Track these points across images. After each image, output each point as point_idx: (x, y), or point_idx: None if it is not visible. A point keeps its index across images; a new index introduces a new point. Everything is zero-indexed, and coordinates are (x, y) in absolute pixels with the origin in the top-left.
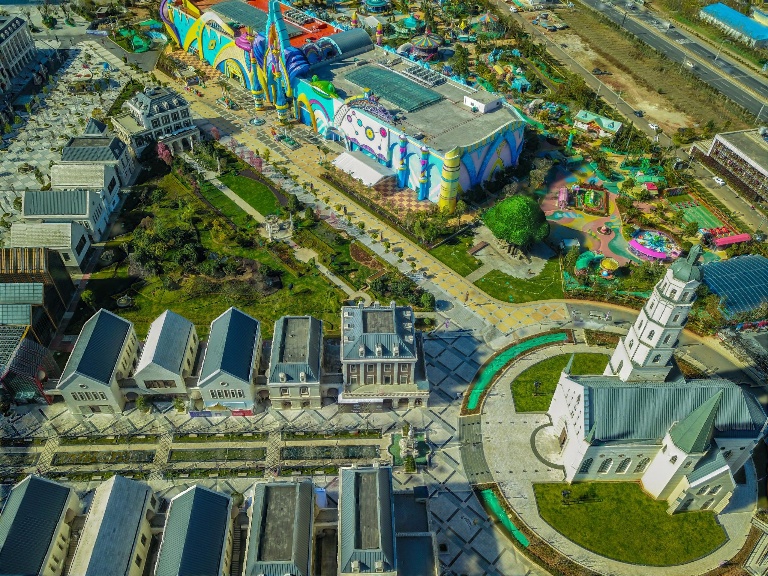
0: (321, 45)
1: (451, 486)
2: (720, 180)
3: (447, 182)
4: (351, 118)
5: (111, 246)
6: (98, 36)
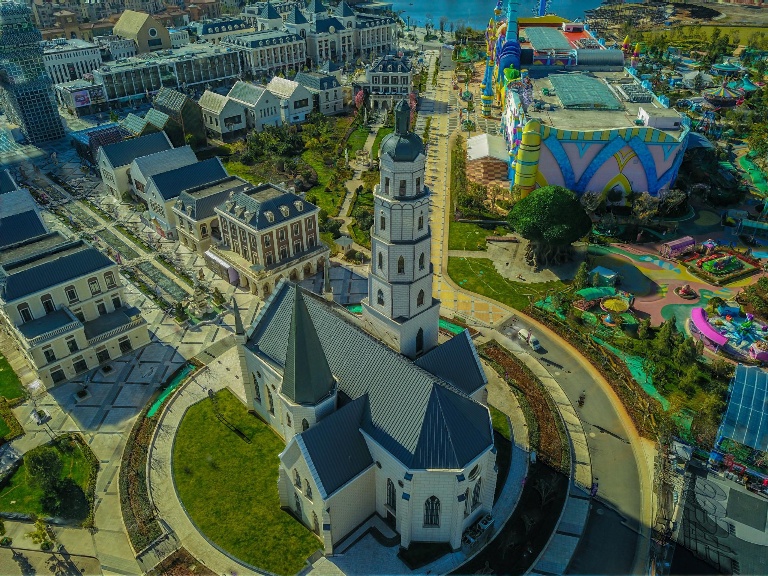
0: (572, 60)
1: (182, 348)
2: None
3: (518, 163)
4: None
5: None
6: (448, 49)
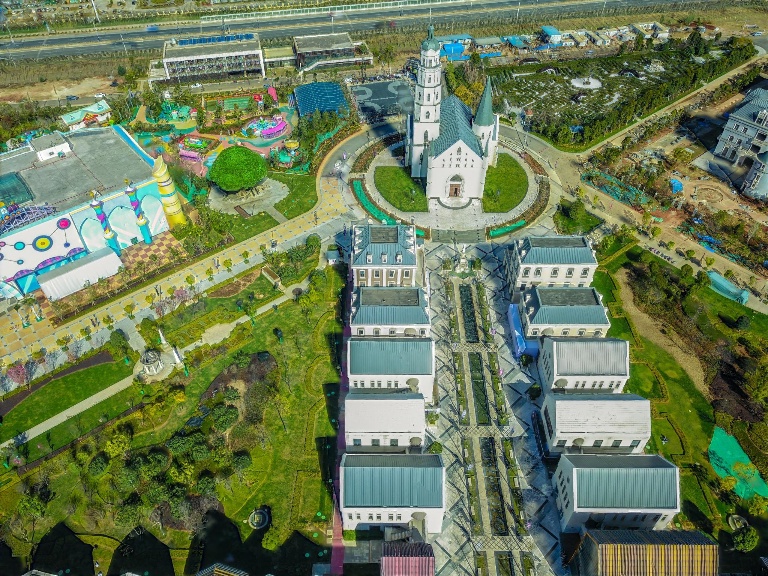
0: None
1: (488, 250)
2: (198, 84)
3: (174, 195)
4: (0, 254)
5: (123, 572)
6: None
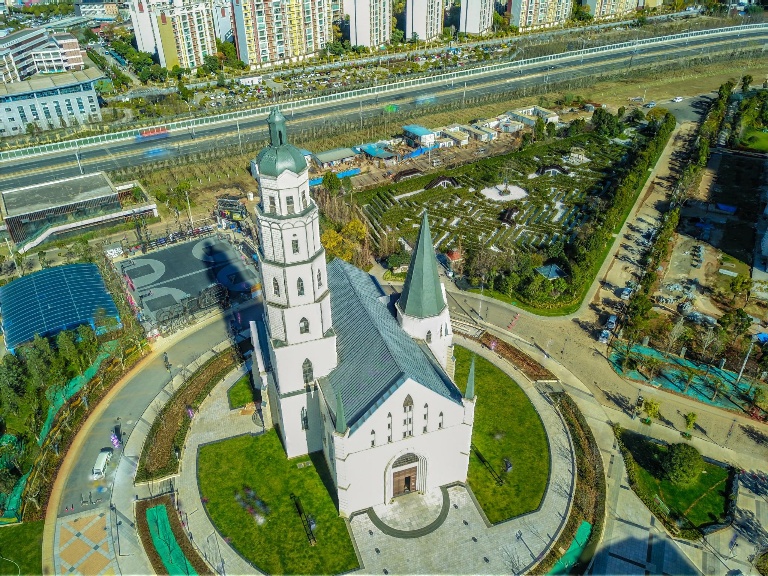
0: None
1: None
2: None
3: None
4: None
5: None
6: None
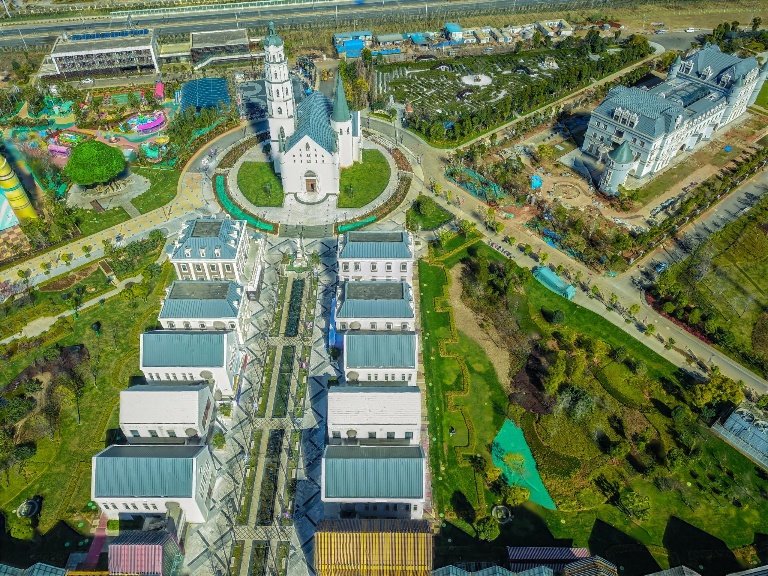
0: None
1: (332, 245)
2: (89, 79)
3: (17, 189)
4: None
5: None
6: None
